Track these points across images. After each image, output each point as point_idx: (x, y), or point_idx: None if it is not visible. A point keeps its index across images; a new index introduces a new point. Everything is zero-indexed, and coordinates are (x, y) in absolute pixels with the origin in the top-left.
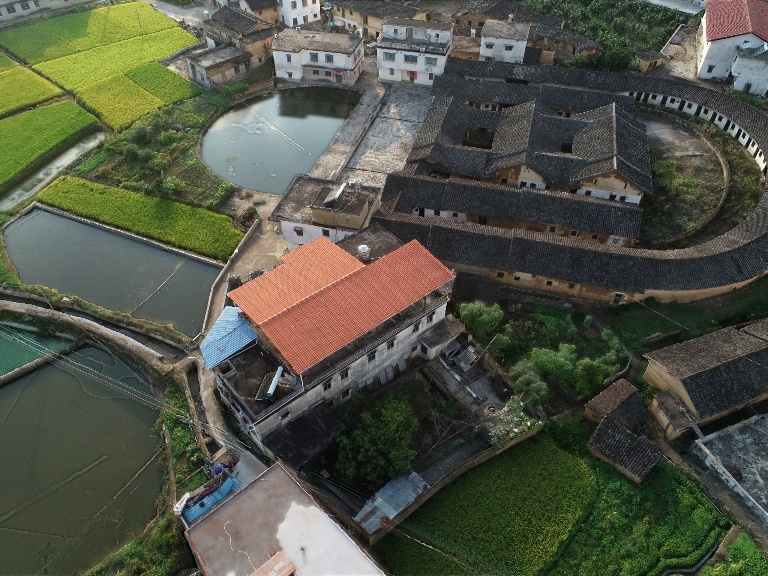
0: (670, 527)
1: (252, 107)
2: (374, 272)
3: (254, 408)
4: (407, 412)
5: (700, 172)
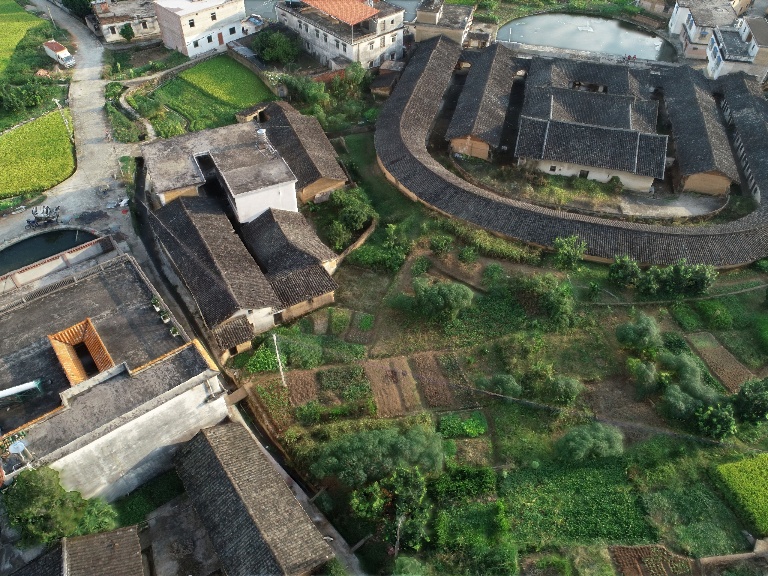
0: (209, 124)
1: (617, 25)
2: (351, 2)
3: (284, 4)
4: (285, 47)
5: (582, 206)
